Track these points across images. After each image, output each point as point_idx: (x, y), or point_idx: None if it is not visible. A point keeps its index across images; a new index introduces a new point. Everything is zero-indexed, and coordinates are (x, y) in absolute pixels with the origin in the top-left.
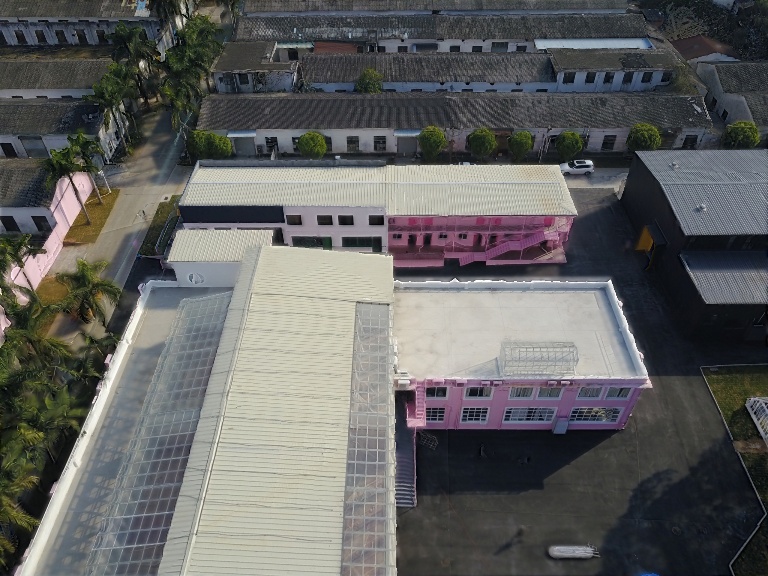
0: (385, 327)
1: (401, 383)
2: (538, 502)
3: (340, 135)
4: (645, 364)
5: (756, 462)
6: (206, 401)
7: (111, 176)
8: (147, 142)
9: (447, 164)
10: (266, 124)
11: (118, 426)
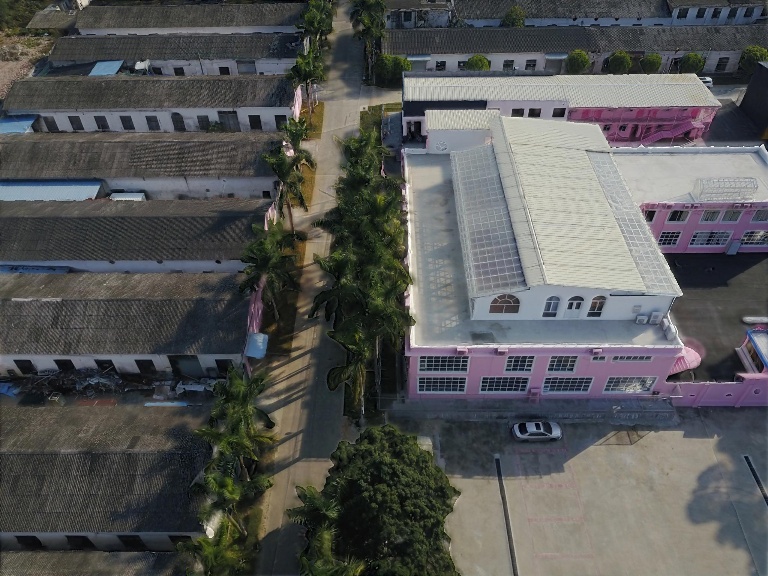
0: (612, 165)
1: None
2: (726, 294)
3: (499, 59)
4: None
5: None
6: (509, 202)
7: None
8: (330, 69)
9: None
10: (438, 50)
11: (427, 232)
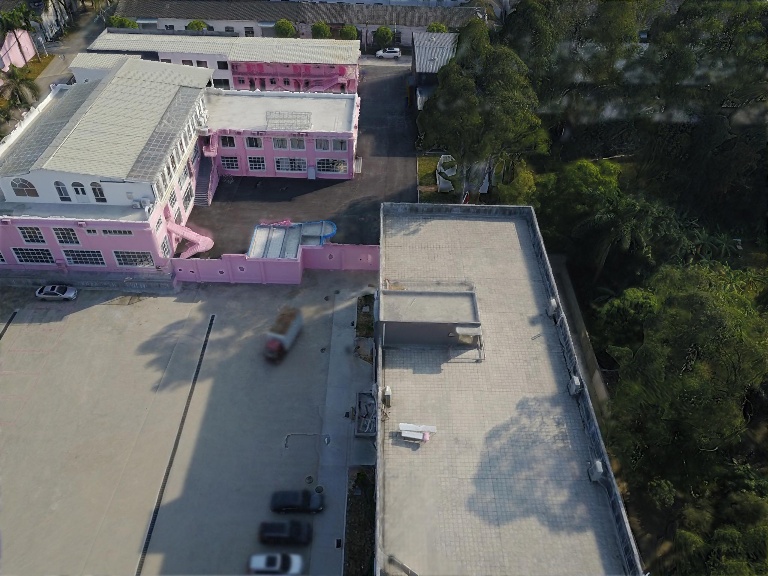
0: (195, 97)
1: (202, 130)
2: (285, 206)
3: (220, 25)
4: (382, 151)
5: (427, 195)
6: (73, 116)
7: (50, 48)
8: (80, 30)
9: None
10: (165, 15)
11: None
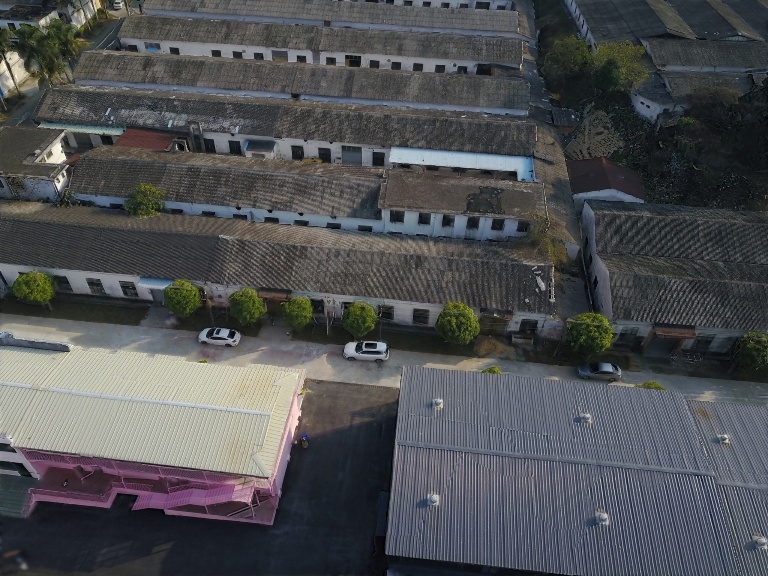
0: None
1: None
2: None
3: (76, 275)
4: None
5: None
6: None
7: None
8: None
9: (208, 325)
10: None
11: None
